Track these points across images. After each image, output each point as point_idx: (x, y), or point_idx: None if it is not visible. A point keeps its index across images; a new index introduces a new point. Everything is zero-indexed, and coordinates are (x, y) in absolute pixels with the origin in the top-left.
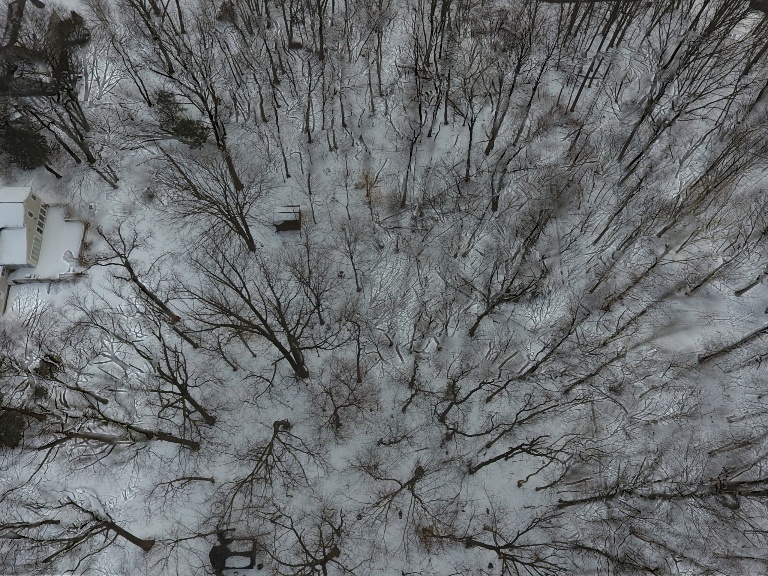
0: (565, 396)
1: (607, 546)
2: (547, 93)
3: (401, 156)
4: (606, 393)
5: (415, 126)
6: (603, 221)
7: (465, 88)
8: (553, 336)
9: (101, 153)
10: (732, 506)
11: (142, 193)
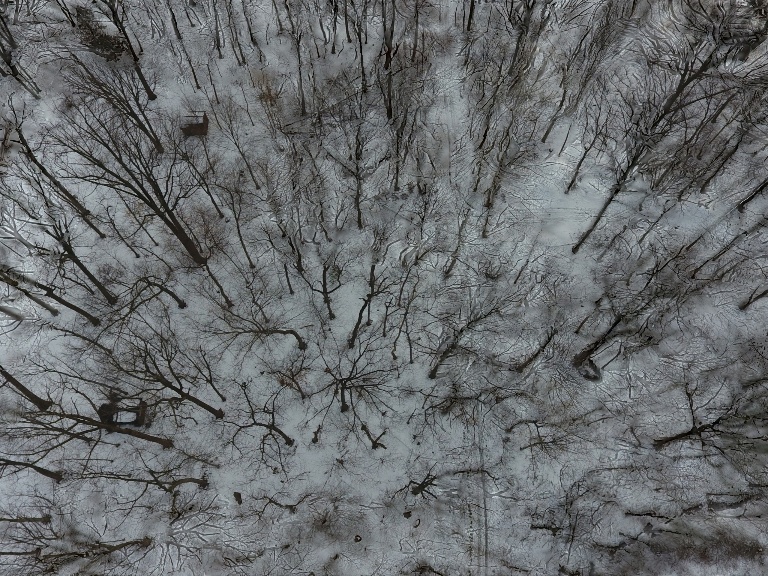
0: (444, 282)
1: (475, 414)
2: (448, 15)
3: (305, 69)
4: (463, 261)
5: (320, 43)
6: (483, 121)
7: (366, 7)
8: (437, 230)
9: (20, 61)
10: (595, 380)
11: (61, 102)
